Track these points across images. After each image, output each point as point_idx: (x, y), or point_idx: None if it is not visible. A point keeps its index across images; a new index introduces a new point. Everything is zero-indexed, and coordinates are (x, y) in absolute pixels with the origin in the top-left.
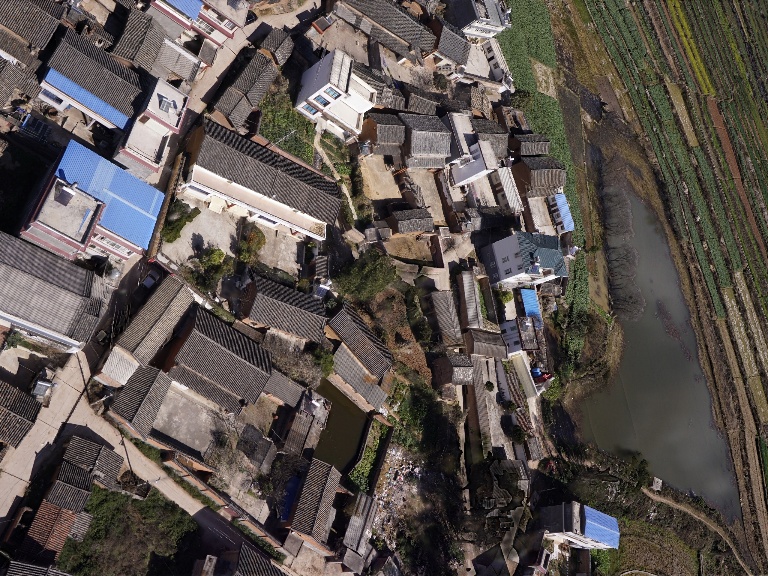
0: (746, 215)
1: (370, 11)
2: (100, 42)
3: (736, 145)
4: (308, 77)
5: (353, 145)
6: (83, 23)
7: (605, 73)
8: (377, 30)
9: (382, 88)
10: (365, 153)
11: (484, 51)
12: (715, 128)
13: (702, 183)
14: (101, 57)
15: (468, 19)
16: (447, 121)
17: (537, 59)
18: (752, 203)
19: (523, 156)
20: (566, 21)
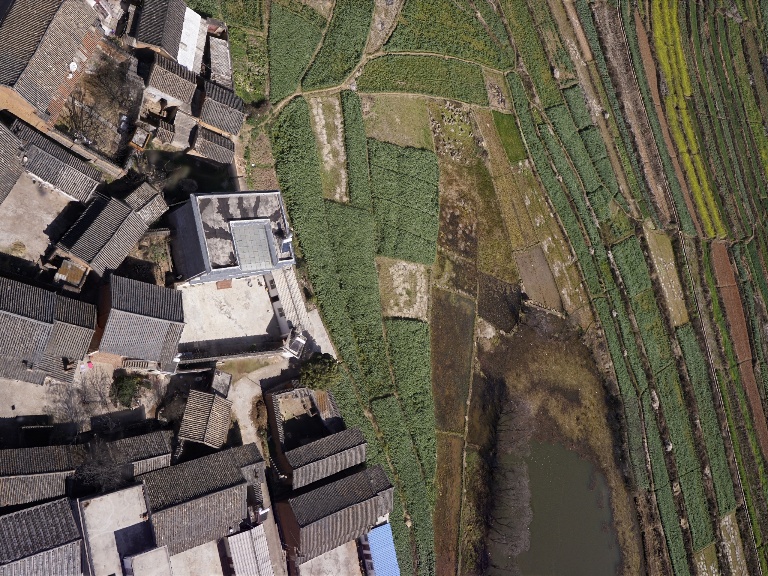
0: (752, 418)
1: None
2: None
3: (750, 309)
4: None
5: None
6: None
7: (538, 240)
8: None
9: None
10: None
11: (266, 284)
12: (719, 289)
13: (685, 383)
14: None
15: (198, 265)
16: (78, 514)
17: (396, 257)
18: (764, 396)
19: (298, 490)
20: (475, 169)
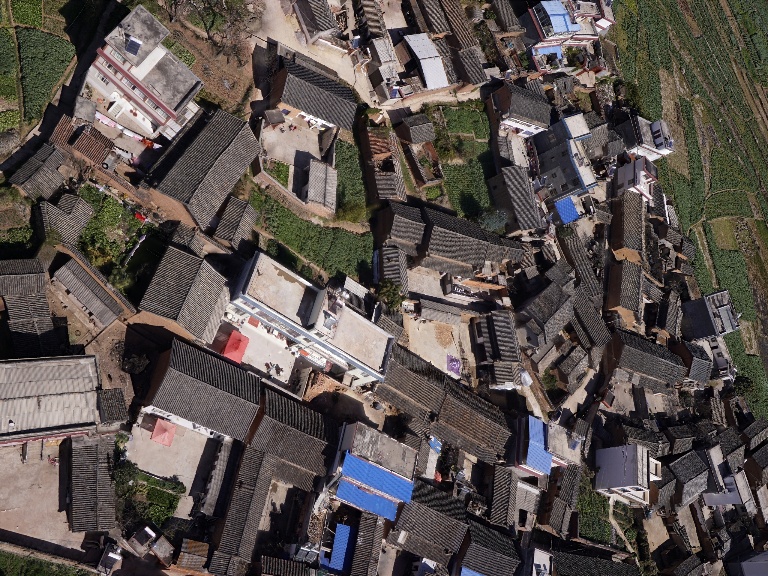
0: None
1: (641, 368)
2: (479, 509)
3: None
4: (605, 460)
5: (638, 509)
6: (468, 497)
7: None
8: (644, 379)
9: (657, 447)
10: (649, 517)
11: None
12: None
13: None
14: (491, 538)
15: (706, 332)
16: (704, 457)
17: (741, 319)
18: None
19: (752, 451)
20: (756, 259)
